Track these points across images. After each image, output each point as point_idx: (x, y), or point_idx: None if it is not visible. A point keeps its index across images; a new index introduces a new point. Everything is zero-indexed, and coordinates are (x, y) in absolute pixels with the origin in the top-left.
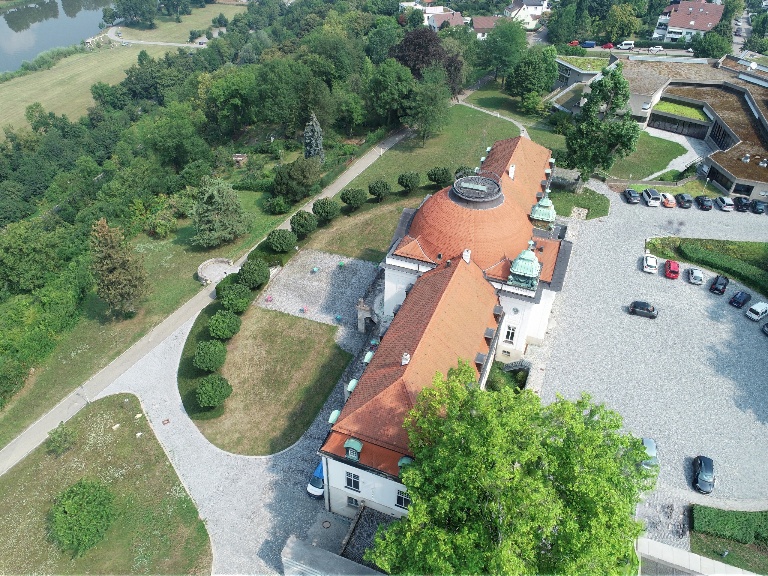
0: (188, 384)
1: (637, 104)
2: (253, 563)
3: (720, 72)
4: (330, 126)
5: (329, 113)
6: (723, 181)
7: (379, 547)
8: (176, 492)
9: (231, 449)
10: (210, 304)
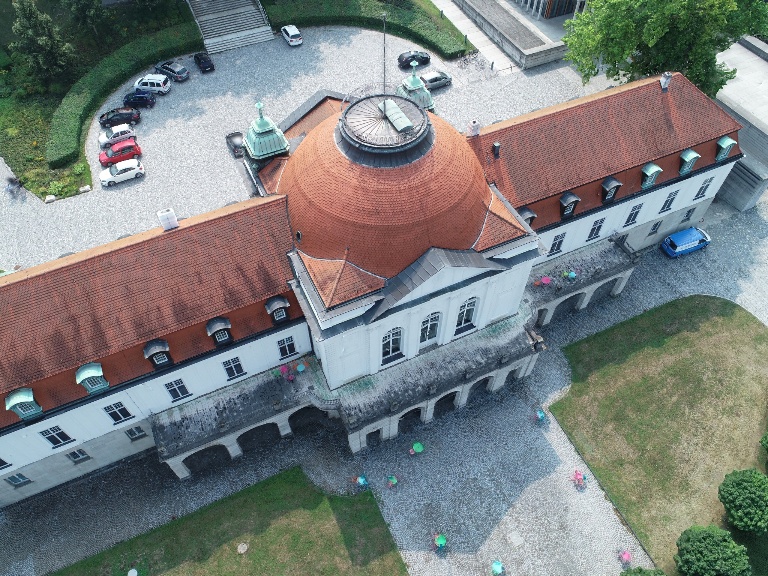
0: None
1: None
2: None
3: None
4: None
5: None
6: None
7: None
8: None
9: None
10: None
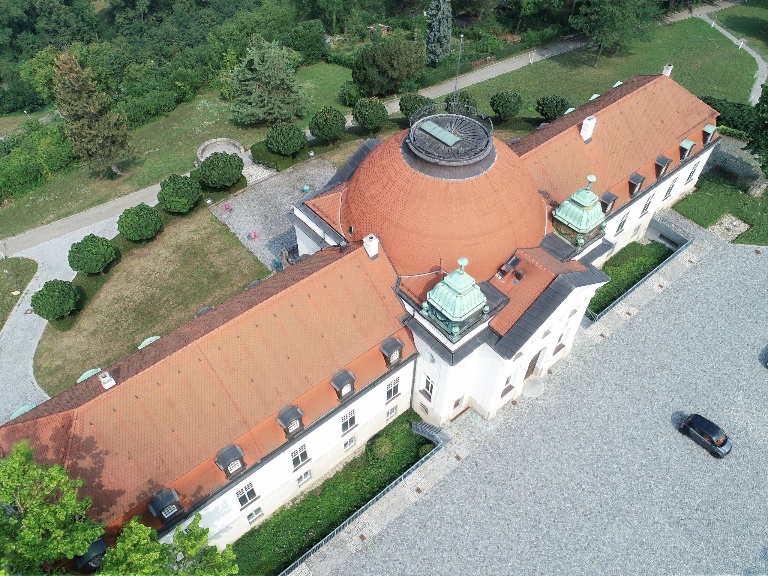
0: (77, 277)
1: None
2: None
3: None
4: (500, 12)
5: None
6: None
7: None
8: None
9: (40, 376)
10: None
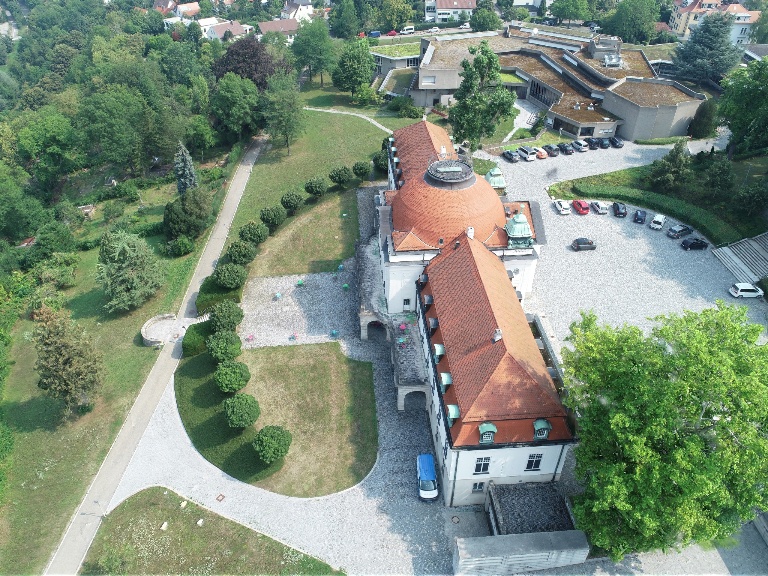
0: (221, 451)
1: None
2: None
3: (512, 40)
4: None
5: None
6: (568, 128)
7: None
8: (292, 557)
9: (317, 493)
10: (181, 365)
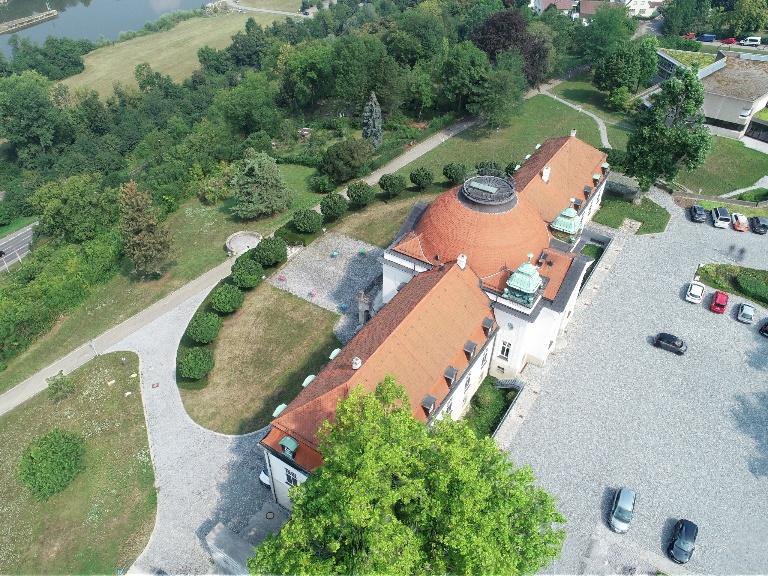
0: (184, 352)
1: (734, 110)
2: (189, 540)
3: None
4: (401, 107)
5: (397, 94)
6: None
7: (258, 557)
8: (141, 456)
9: (203, 423)
10: (229, 276)
